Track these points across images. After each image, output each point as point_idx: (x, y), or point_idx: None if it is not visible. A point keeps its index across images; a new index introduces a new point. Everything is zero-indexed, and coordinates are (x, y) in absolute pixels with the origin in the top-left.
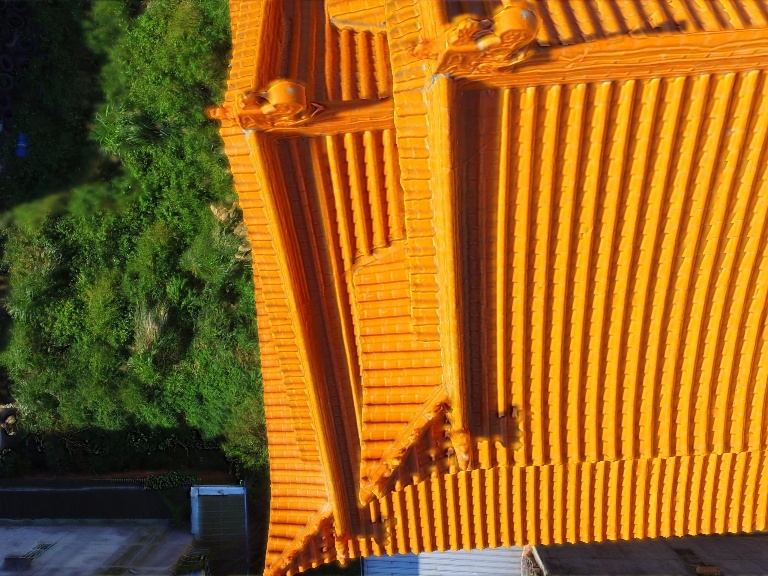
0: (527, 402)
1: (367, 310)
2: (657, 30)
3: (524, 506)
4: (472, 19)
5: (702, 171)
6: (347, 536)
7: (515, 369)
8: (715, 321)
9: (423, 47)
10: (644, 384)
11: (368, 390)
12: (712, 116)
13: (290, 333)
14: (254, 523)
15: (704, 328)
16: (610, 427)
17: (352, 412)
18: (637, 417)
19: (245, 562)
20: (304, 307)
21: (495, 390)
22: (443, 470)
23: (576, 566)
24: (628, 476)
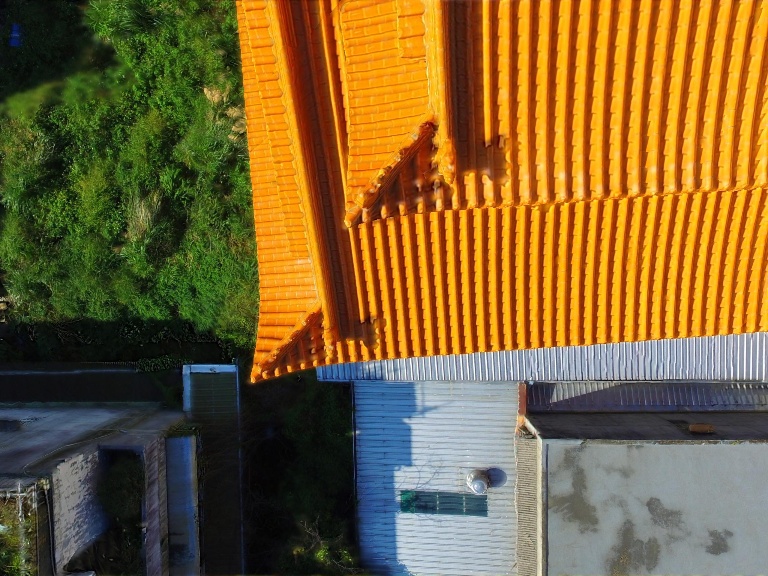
0: (514, 130)
1: (354, 47)
2: None
3: (514, 305)
4: None
5: None
6: (336, 332)
7: (502, 90)
8: (702, 31)
9: None
10: (631, 109)
11: (354, 126)
12: None
13: (277, 90)
14: (246, 403)
15: (691, 40)
16: (597, 158)
17: (340, 190)
18: (624, 148)
19: (237, 440)
20: (291, 51)
21: (482, 114)
22: (430, 204)
23: (568, 429)
24: (618, 270)
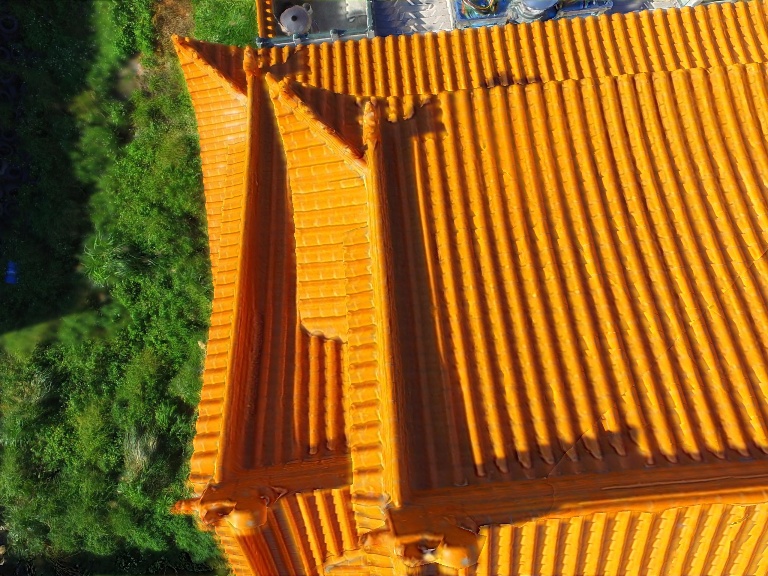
0: None
1: None
2: (609, 435)
3: None
4: (416, 557)
5: (656, 550)
6: None
7: None
8: None
9: (373, 543)
10: None
11: None
12: (663, 517)
13: None
14: None
15: None
16: None
17: None
18: None
19: None
20: None
21: None
22: None
23: None
24: None
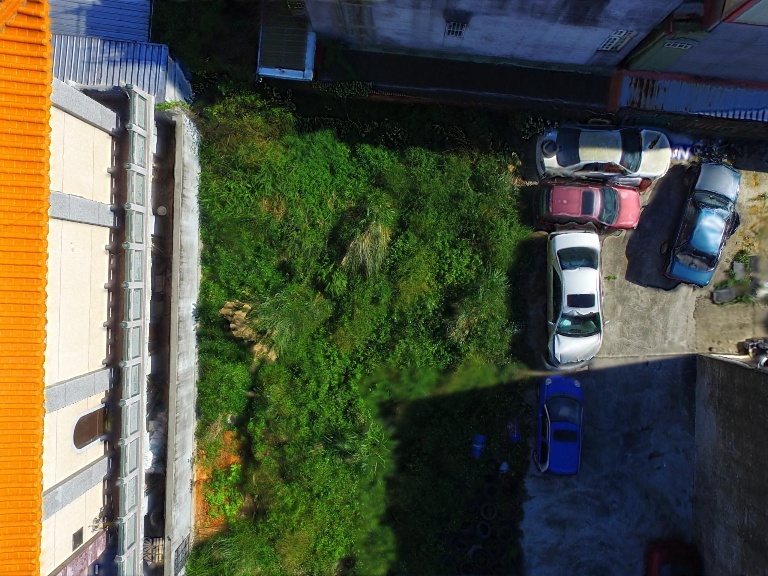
0: None
1: None
2: None
3: None
4: None
5: None
6: None
7: None
8: None
9: None
10: None
11: None
12: None
13: None
14: None
15: None
16: None
17: None
18: None
19: None
20: None
21: None
22: None
23: None
24: None
